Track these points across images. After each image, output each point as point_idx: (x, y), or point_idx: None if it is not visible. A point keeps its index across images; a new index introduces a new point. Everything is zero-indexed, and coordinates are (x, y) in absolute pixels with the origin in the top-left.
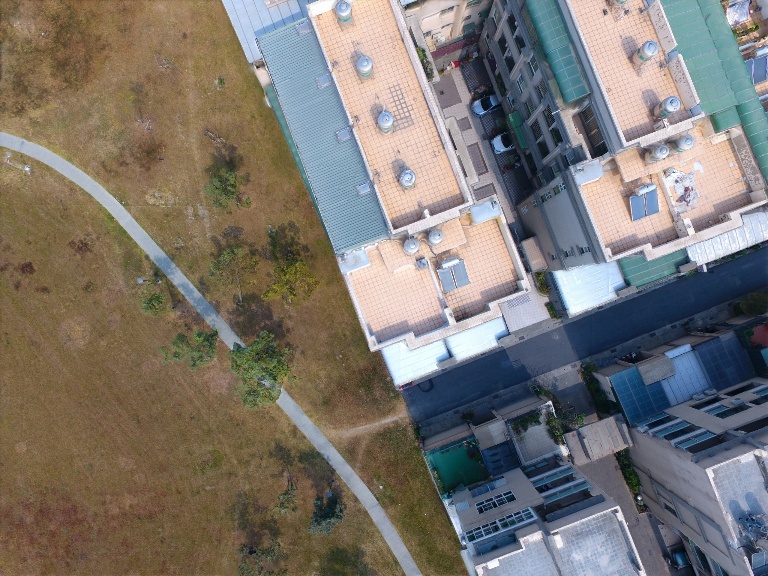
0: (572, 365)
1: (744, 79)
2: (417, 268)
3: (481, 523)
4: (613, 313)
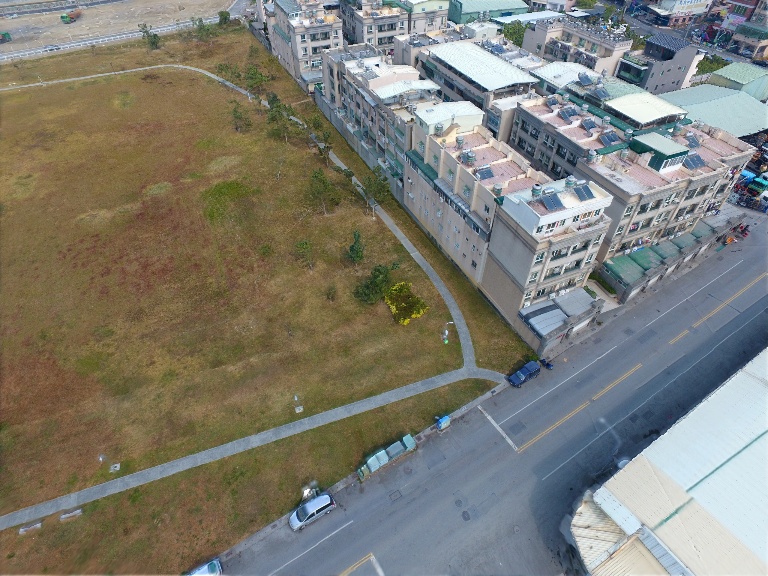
0: None
1: None
2: (310, 19)
3: None
4: None
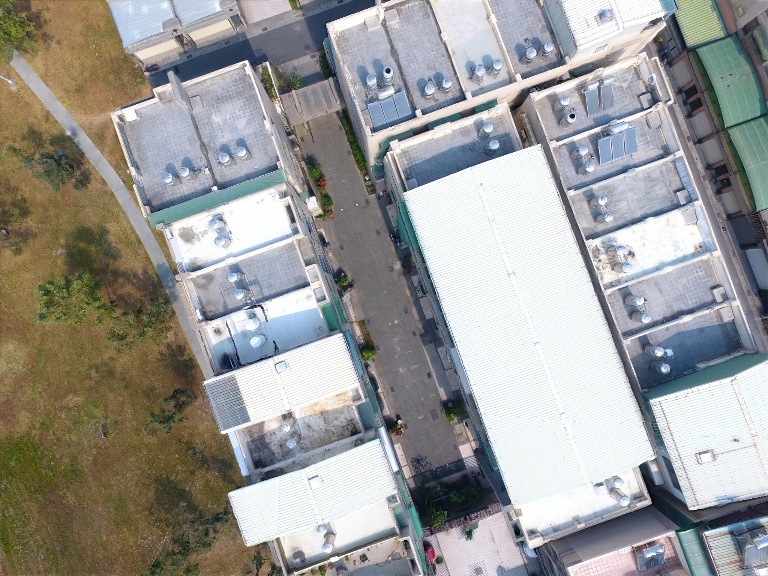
0: (311, 56)
1: None
2: None
3: None
4: (352, 7)
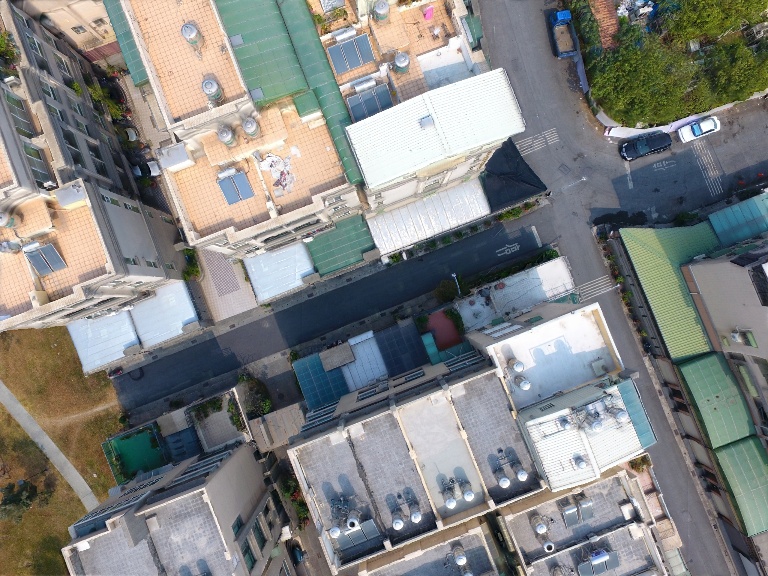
0: (282, 353)
1: (318, 63)
2: None
3: (104, 507)
4: (323, 301)
